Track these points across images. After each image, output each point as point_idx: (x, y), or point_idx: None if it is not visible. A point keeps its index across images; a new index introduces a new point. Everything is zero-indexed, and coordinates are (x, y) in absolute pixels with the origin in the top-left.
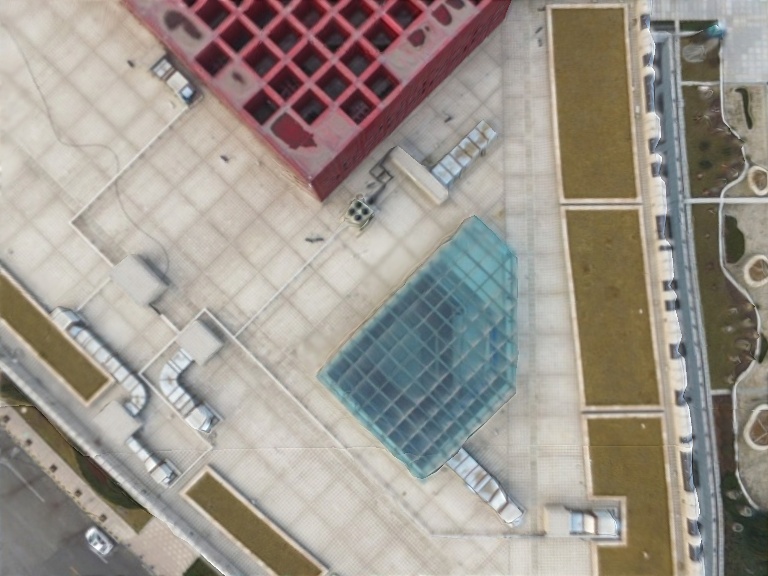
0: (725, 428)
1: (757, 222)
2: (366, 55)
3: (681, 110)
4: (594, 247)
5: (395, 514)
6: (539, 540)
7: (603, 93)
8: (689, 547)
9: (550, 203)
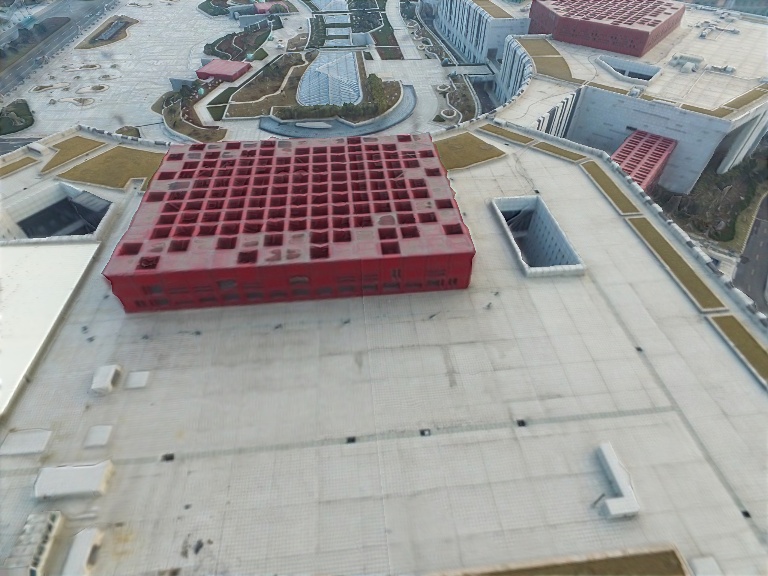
0: None
1: None
2: None
3: None
4: (488, 3)
5: None
6: None
7: None
8: None
9: None
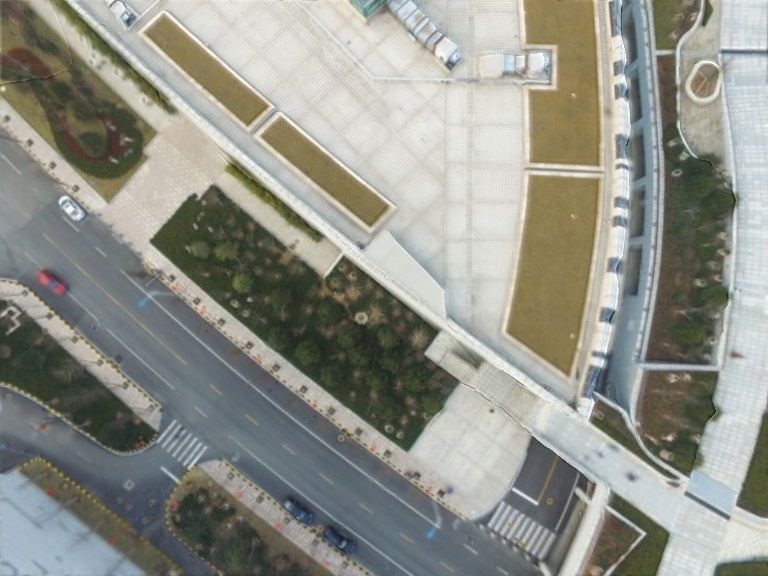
0: (668, 83)
1: None
2: None
3: None
4: None
5: (340, 61)
6: (475, 87)
7: None
8: (615, 88)
9: None
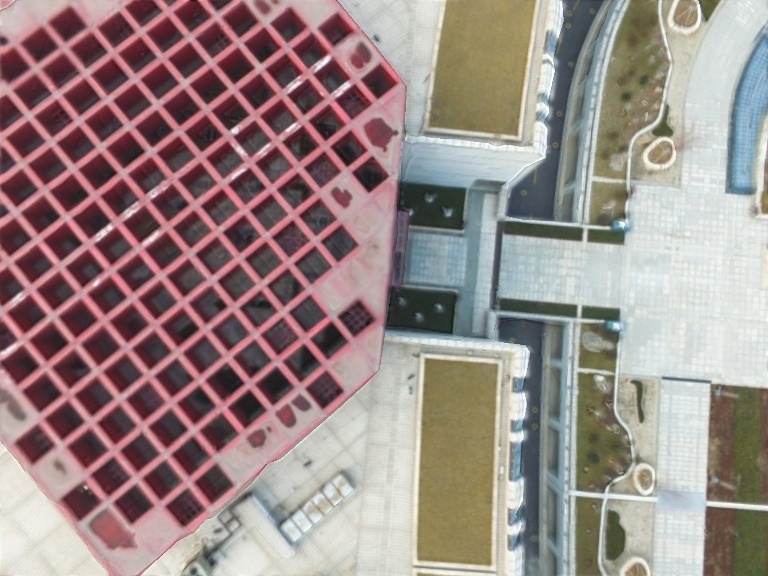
0: None
1: (639, 519)
2: (202, 451)
3: (575, 397)
4: None
5: None
6: None
7: (468, 451)
8: None
9: (403, 561)
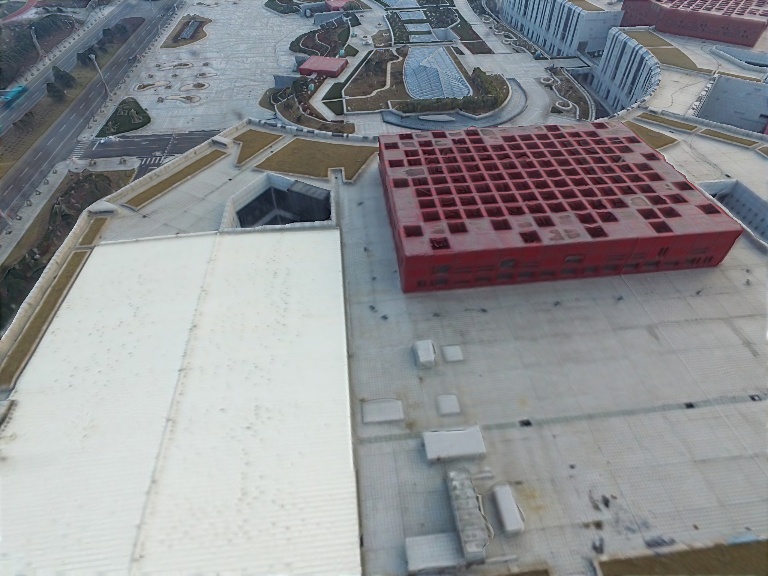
0: None
1: (502, 39)
2: None
3: None
4: None
5: None
6: None
7: None
8: None
9: None
